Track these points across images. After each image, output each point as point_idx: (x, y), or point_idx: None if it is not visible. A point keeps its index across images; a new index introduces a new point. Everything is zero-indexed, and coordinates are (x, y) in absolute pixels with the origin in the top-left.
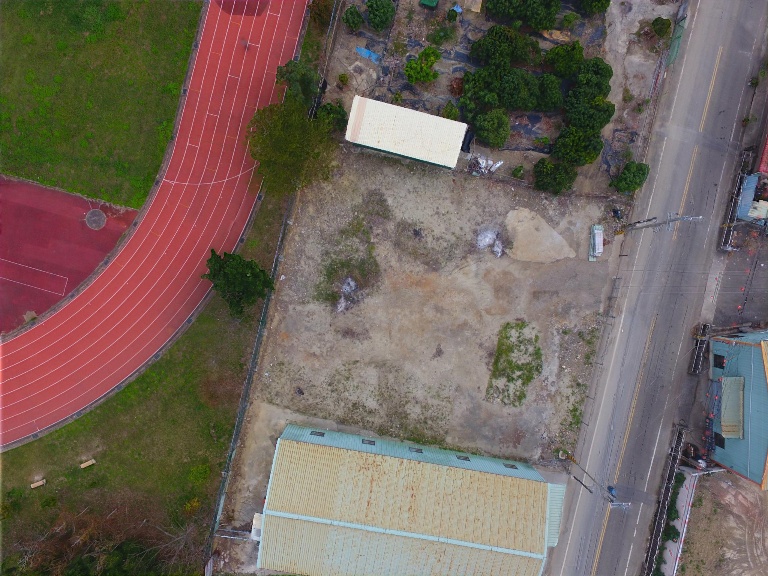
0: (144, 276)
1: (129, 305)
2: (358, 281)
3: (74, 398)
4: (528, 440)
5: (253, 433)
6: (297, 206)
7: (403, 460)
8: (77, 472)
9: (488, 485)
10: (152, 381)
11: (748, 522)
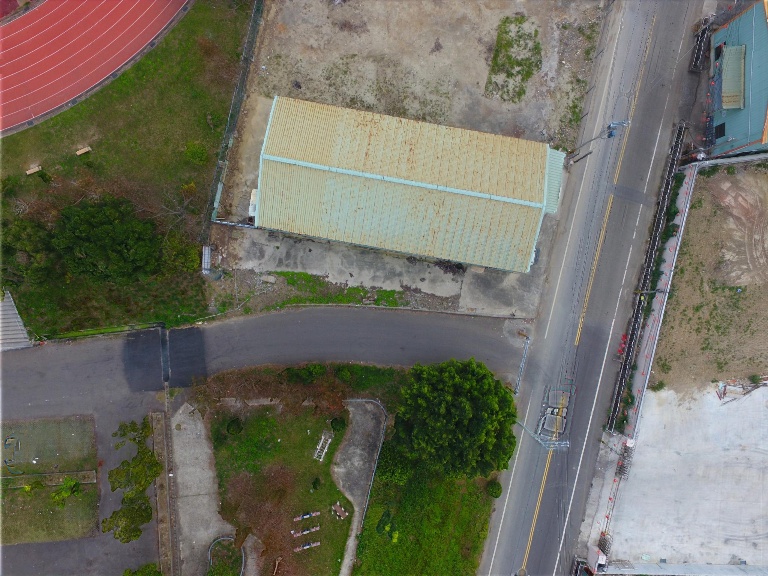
0: None
1: None
2: None
3: (69, 85)
4: (527, 137)
5: (250, 127)
6: None
7: (401, 119)
8: (73, 160)
9: (487, 143)
10: (148, 69)
11: (748, 224)
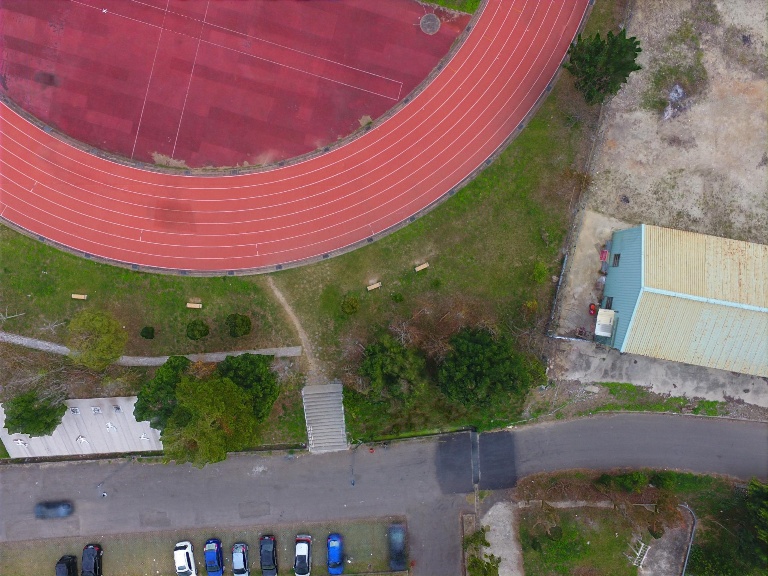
0: (477, 81)
1: (462, 110)
2: (686, 88)
3: (408, 202)
4: None
5: (579, 241)
6: (627, 12)
7: (766, 246)
8: (411, 276)
9: None
10: (484, 186)
11: None
